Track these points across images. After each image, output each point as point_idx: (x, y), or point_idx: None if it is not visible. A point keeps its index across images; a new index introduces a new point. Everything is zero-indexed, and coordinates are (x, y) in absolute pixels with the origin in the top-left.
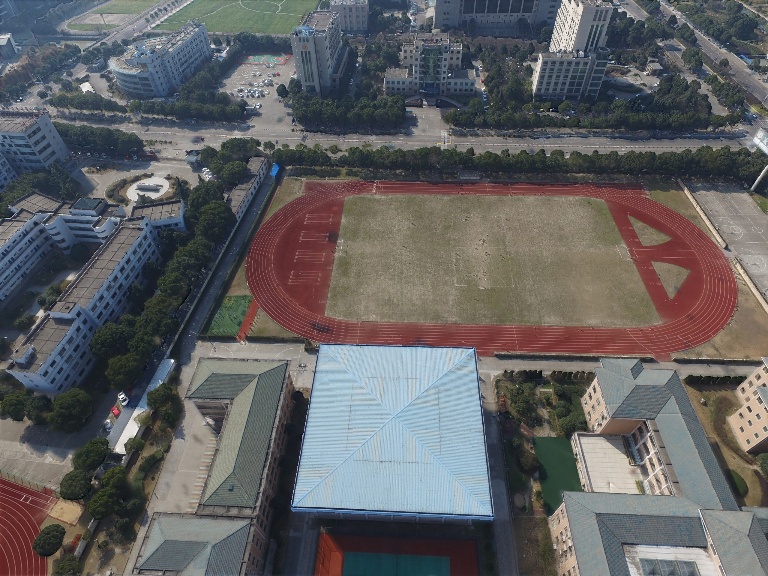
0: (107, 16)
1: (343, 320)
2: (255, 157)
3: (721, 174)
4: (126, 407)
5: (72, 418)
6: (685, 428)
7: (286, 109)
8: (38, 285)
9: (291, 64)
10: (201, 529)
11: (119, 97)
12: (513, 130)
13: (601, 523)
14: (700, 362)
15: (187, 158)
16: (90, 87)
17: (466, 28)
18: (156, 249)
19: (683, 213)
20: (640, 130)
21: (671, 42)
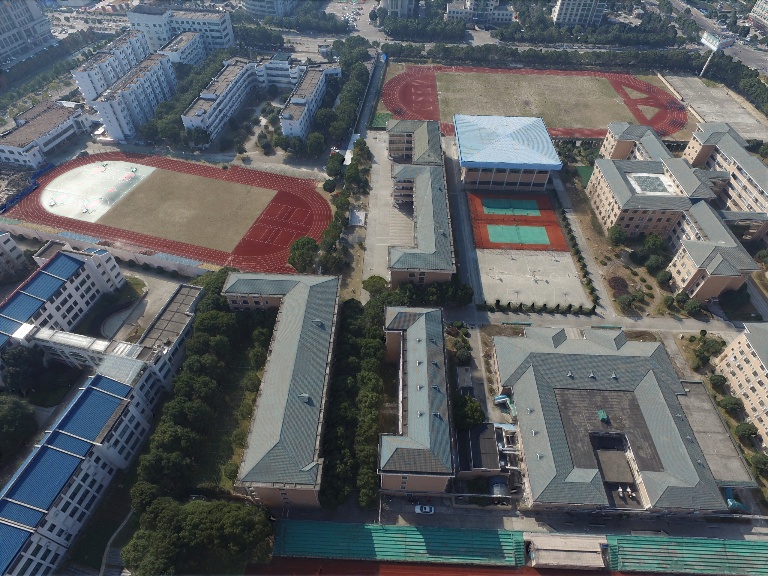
0: None
1: (453, 124)
2: (370, 48)
3: (682, 68)
4: (341, 150)
5: (320, 144)
6: (655, 139)
7: (376, 28)
8: (252, 107)
9: (369, 3)
10: None
11: None
12: (542, 44)
13: (615, 163)
14: (664, 142)
15: (321, 49)
16: (224, 10)
17: None
18: (325, 88)
19: (657, 85)
20: (629, 46)
21: (650, 0)
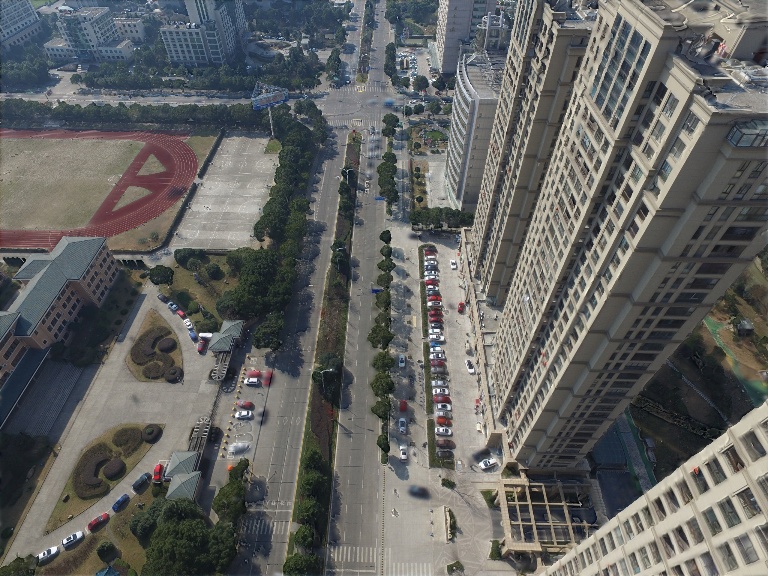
0: None
1: None
2: None
3: None
4: None
5: None
6: None
7: None
8: None
9: None
10: None
11: None
12: (133, 90)
13: None
14: None
15: None
16: None
17: None
18: None
19: (198, 152)
20: (240, 91)
21: (356, 23)
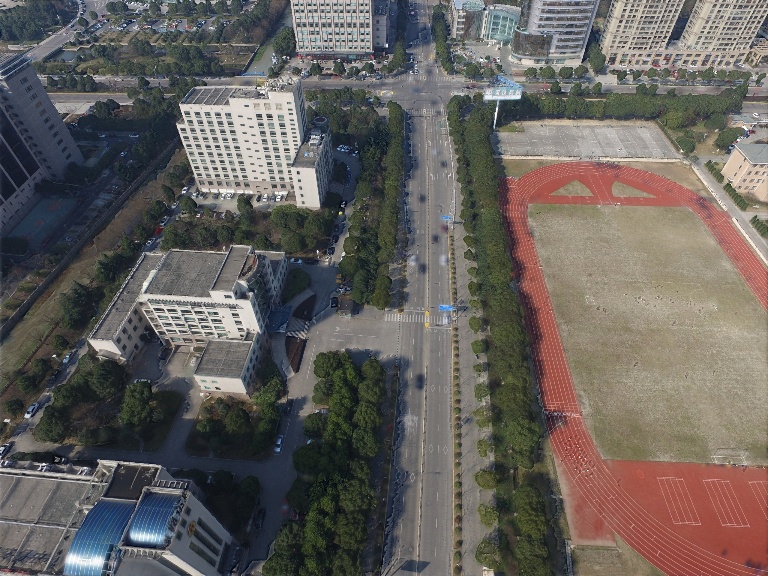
0: None
1: None
2: None
3: None
4: None
5: None
6: None
7: None
8: None
9: None
10: None
11: None
12: None
13: None
14: None
15: None
16: None
17: None
18: None
19: (537, 166)
20: None
21: None
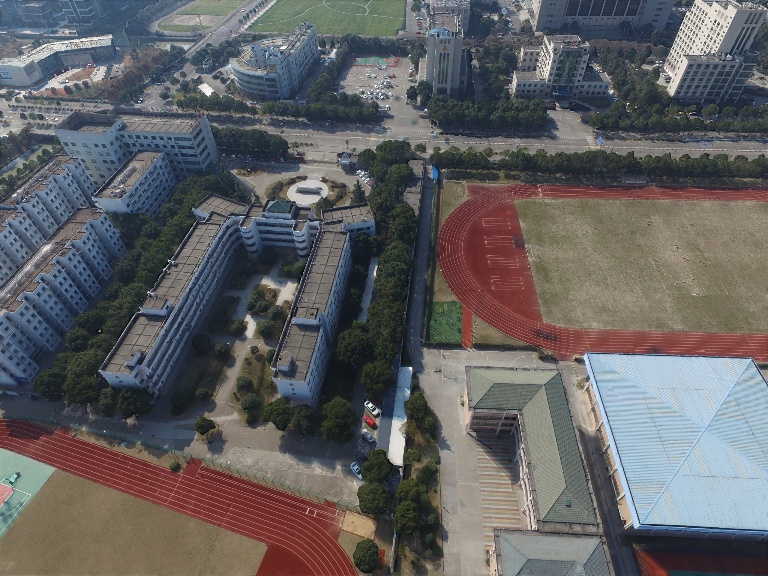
0: (195, 17)
1: (565, 327)
2: (413, 160)
3: None
4: (382, 416)
5: (346, 428)
6: None
7: (417, 111)
8: (234, 289)
9: (403, 66)
10: (556, 547)
11: (240, 98)
12: (659, 134)
13: None
14: None
15: (341, 160)
16: (210, 88)
17: (568, 31)
18: (350, 253)
19: None
20: None
21: None
